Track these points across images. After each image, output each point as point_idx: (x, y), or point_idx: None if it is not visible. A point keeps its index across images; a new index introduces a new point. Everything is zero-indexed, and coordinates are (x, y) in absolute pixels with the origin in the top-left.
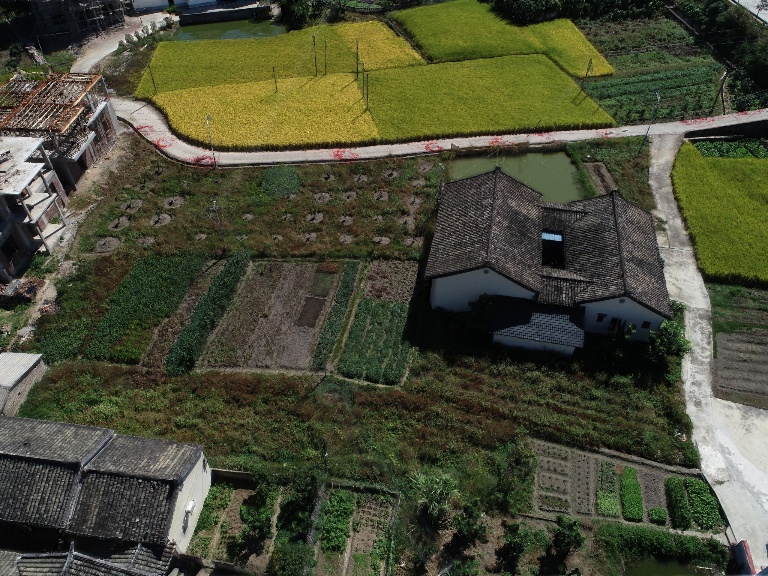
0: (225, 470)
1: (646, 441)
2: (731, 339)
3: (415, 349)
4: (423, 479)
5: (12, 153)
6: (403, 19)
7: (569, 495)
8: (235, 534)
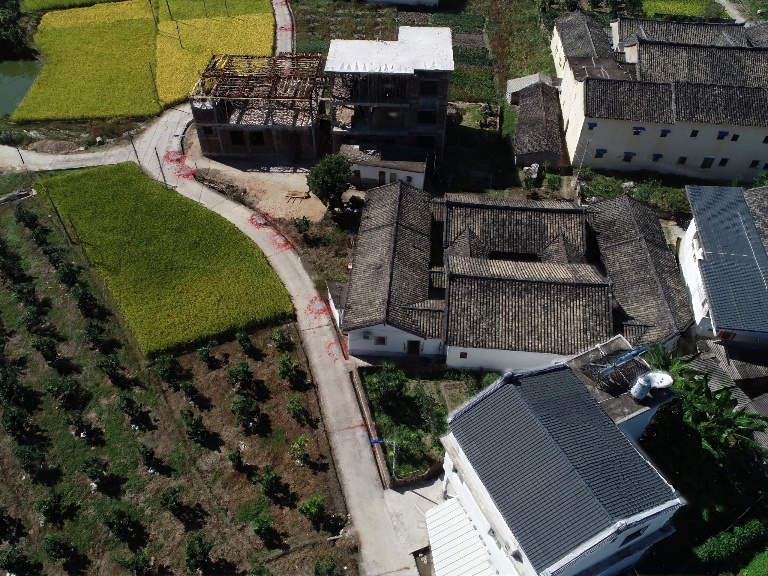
0: None
1: None
2: None
3: None
4: None
5: None
6: (48, 4)
7: None
8: None
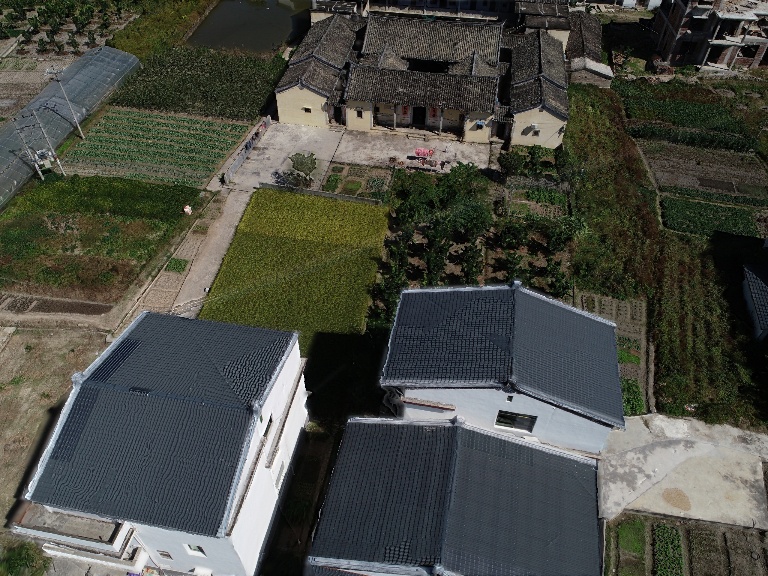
0: (563, 147)
1: (672, 373)
2: None
3: (707, 237)
4: (587, 235)
5: (759, 8)
6: None
7: (599, 315)
8: (527, 159)
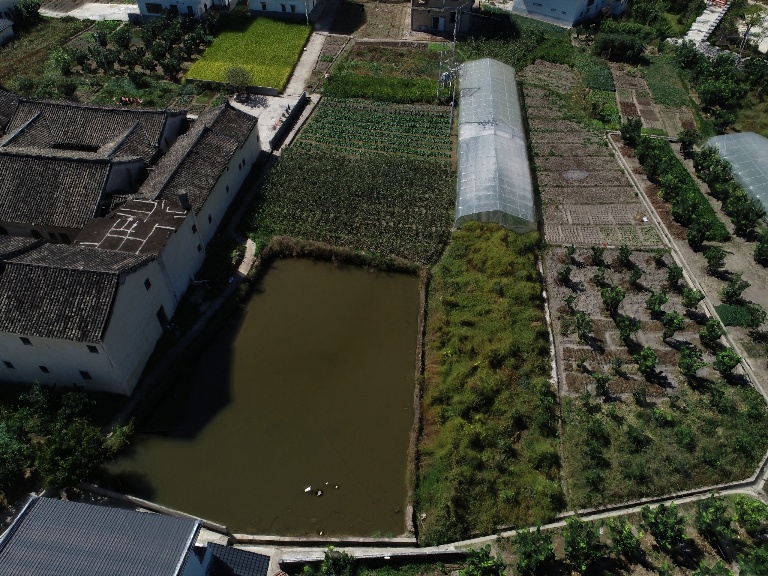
0: None
1: (75, 26)
2: (42, 6)
3: None
4: None
5: None
6: None
7: (85, 47)
8: None
